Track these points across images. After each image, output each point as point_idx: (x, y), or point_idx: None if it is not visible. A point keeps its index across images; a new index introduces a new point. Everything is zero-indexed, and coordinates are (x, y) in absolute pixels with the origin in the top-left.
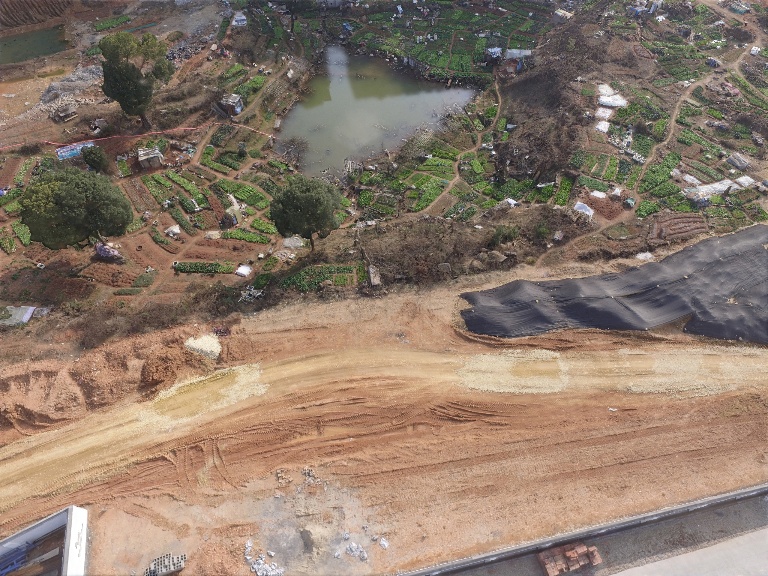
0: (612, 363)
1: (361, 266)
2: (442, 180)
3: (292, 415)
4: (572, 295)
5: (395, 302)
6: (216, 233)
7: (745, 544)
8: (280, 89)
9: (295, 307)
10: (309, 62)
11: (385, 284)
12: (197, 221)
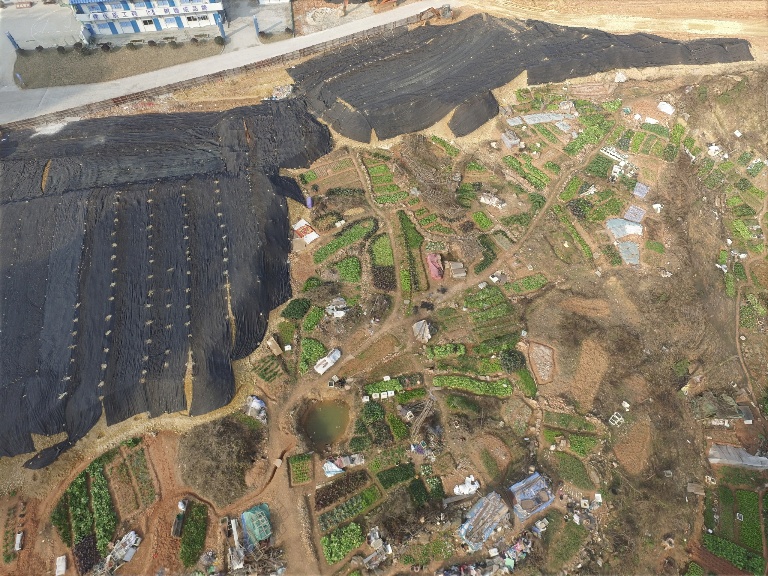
0: (658, 26)
1: None
2: None
3: None
4: (684, 48)
5: None
6: None
7: None
8: None
9: None
10: None
11: None
12: None
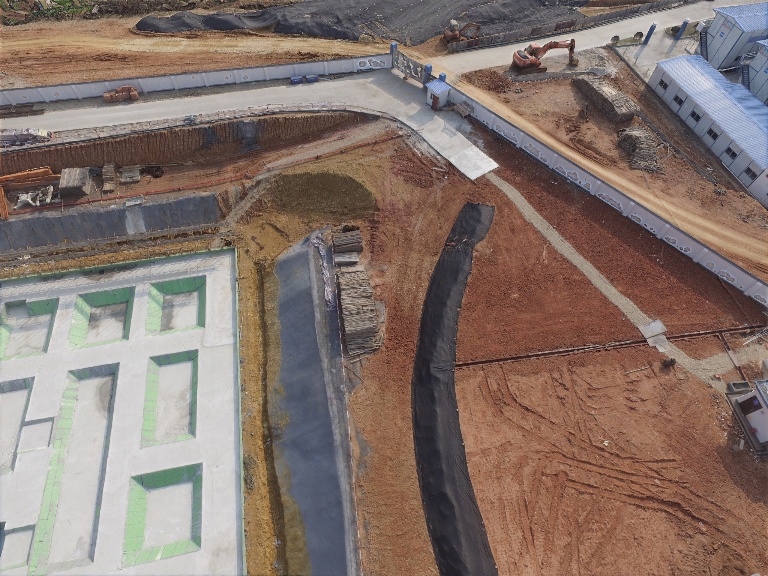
0: (215, 42)
1: (91, 6)
2: None
3: (8, 56)
4: None
5: (102, 20)
6: (24, 12)
7: (225, 95)
8: None
9: (38, 22)
10: None
11: (100, 13)
12: (14, 6)
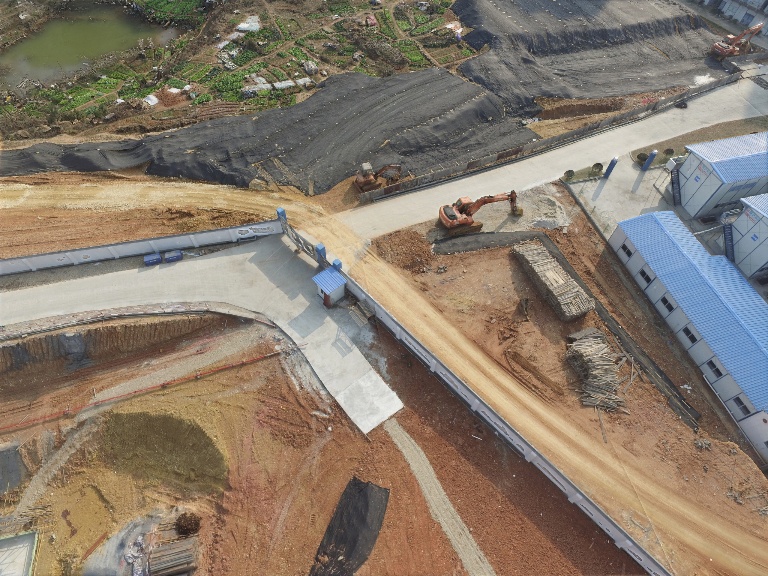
0: (67, 191)
1: None
2: (98, 93)
3: None
4: None
5: None
6: None
7: (53, 287)
8: (1, 26)
9: None
10: (51, 8)
11: None
12: None
